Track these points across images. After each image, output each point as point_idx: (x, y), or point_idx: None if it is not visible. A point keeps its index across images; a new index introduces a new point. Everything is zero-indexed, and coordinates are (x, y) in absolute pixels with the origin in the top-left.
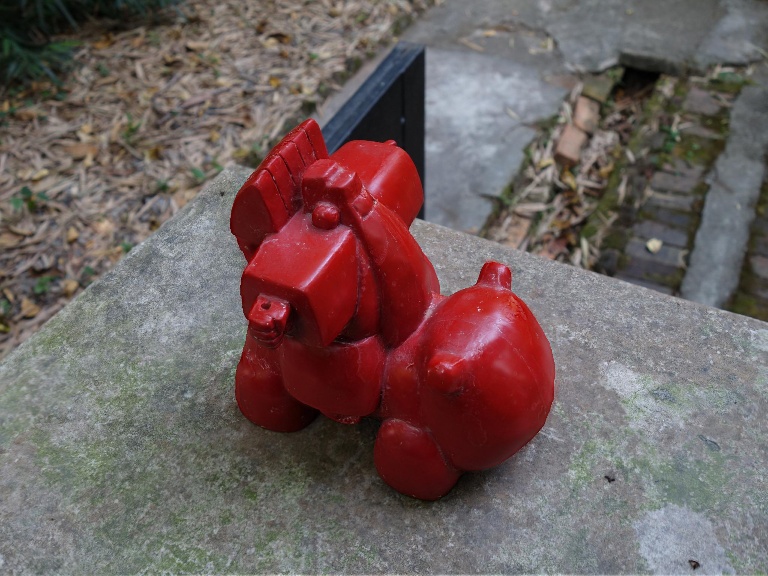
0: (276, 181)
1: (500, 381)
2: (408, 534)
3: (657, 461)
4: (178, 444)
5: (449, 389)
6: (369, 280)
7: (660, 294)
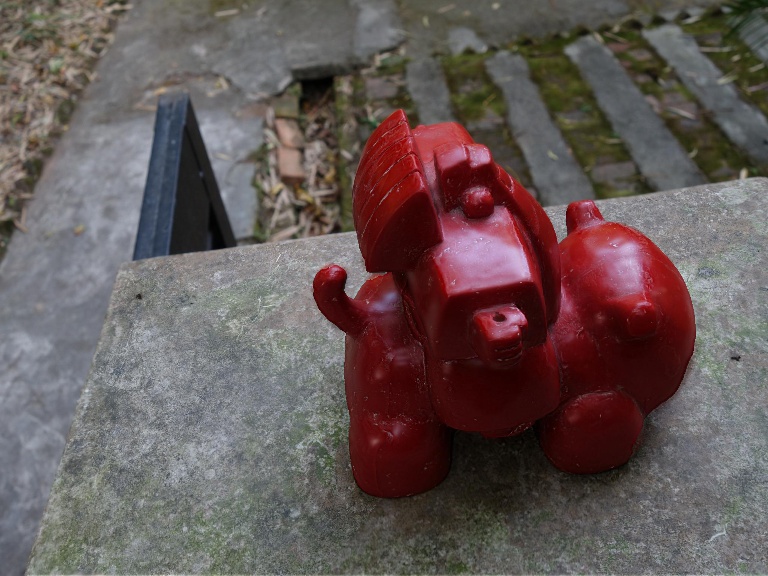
0: None
1: (675, 300)
2: (634, 505)
3: (753, 324)
4: (332, 569)
5: (656, 326)
6: (534, 255)
7: (629, 198)
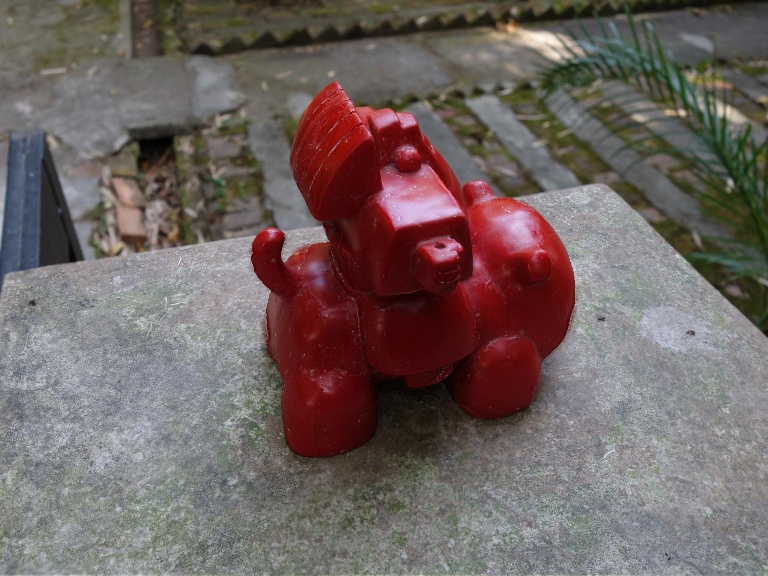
0: None
1: (560, 255)
2: (539, 438)
3: (610, 293)
4: (278, 524)
5: None
6: None
7: None
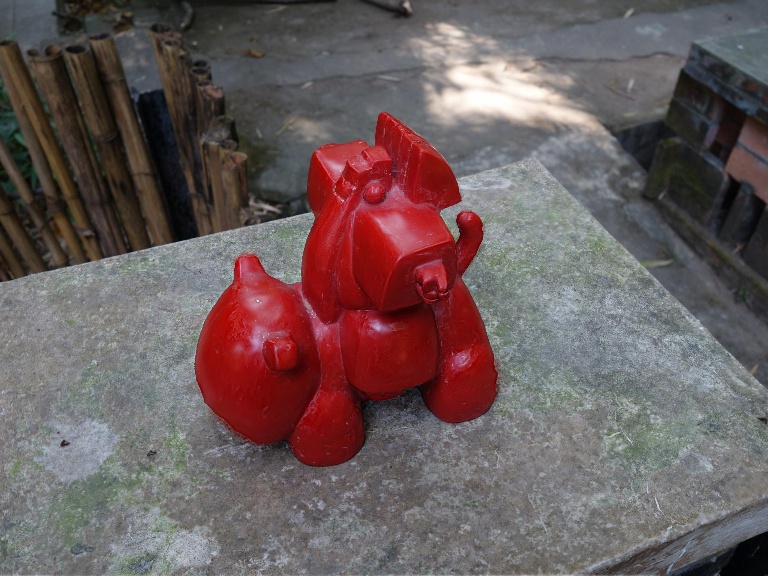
0: None
1: None
2: None
3: (121, 496)
4: None
5: None
6: None
7: None
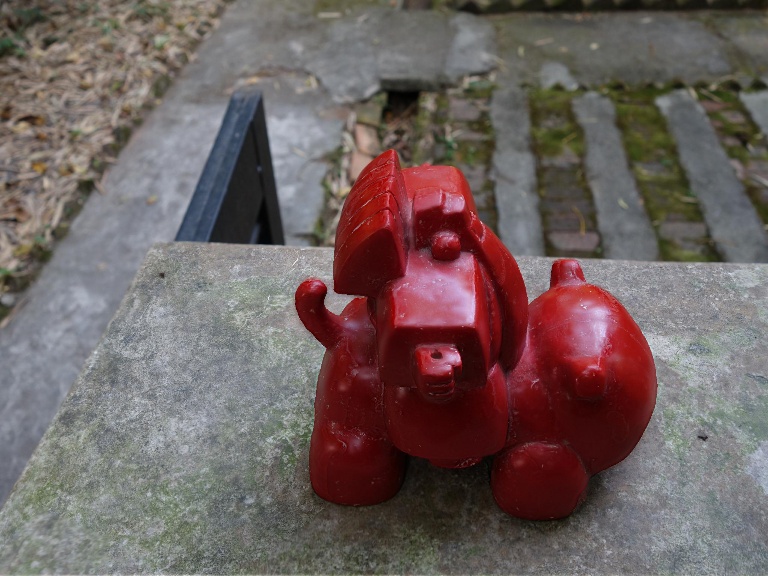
0: (396, 220)
1: (632, 370)
2: (564, 558)
3: (729, 408)
4: (269, 558)
5: (603, 391)
6: (495, 304)
7: (641, 263)
